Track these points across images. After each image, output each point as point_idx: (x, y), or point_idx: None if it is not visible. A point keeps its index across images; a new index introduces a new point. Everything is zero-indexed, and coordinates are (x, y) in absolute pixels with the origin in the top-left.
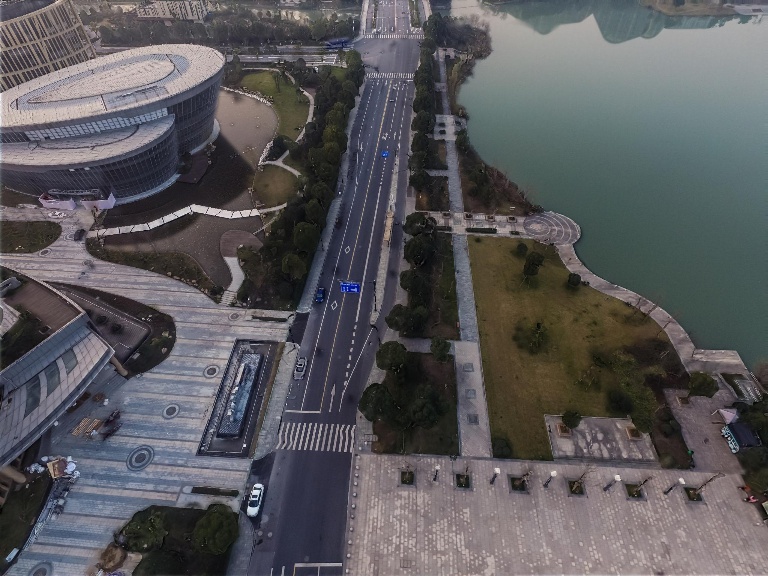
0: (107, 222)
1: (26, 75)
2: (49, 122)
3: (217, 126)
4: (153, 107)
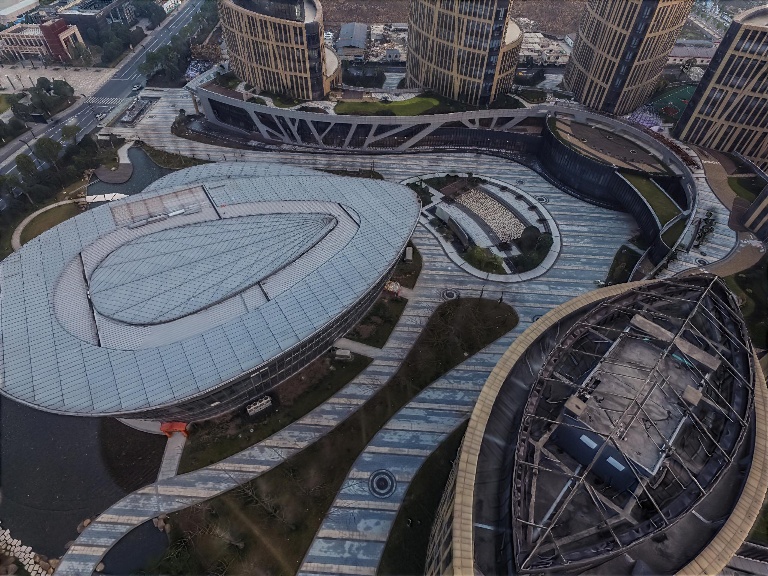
0: None
1: None
2: None
3: None
4: None
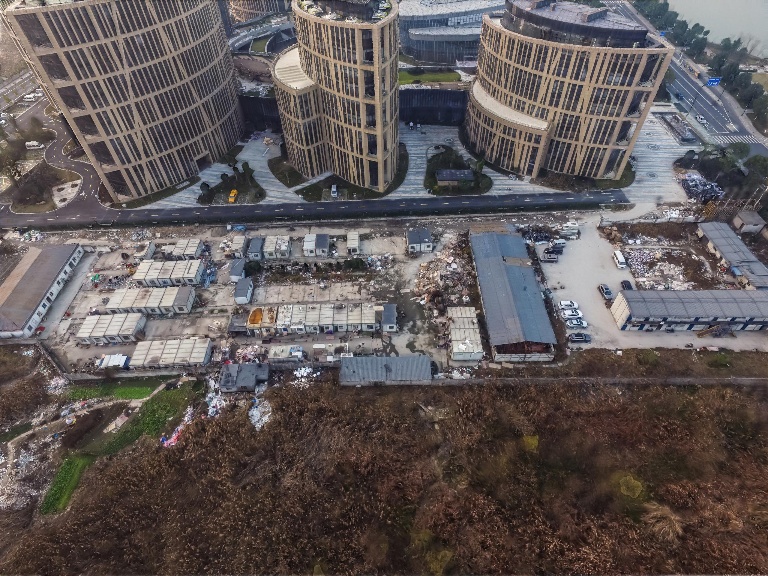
0: None
1: None
2: (468, 11)
3: None
4: None
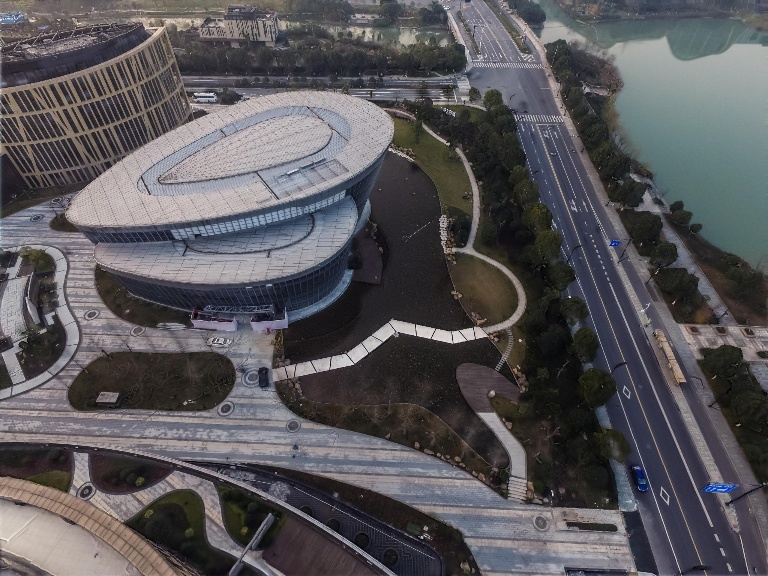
0: (289, 351)
1: (118, 128)
2: (207, 218)
3: None
4: (333, 191)
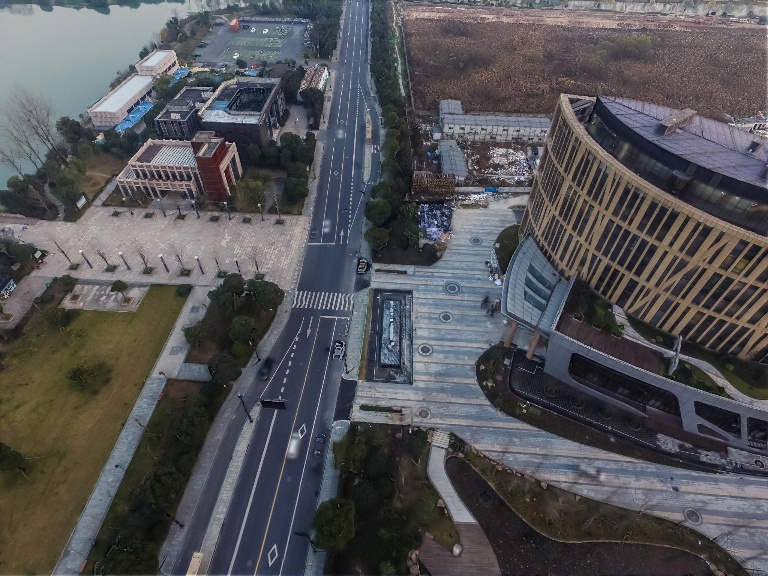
0: None
1: None
2: None
3: None
4: None
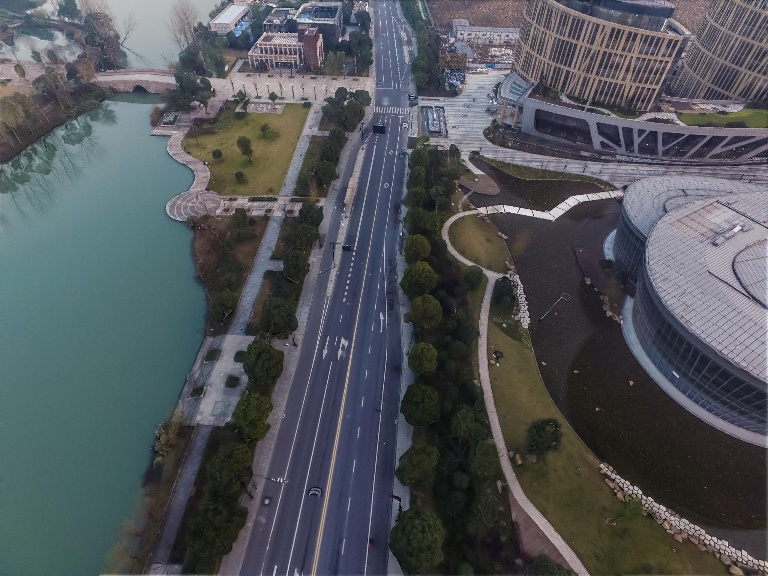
0: None
1: None
2: None
3: (653, 372)
4: None
